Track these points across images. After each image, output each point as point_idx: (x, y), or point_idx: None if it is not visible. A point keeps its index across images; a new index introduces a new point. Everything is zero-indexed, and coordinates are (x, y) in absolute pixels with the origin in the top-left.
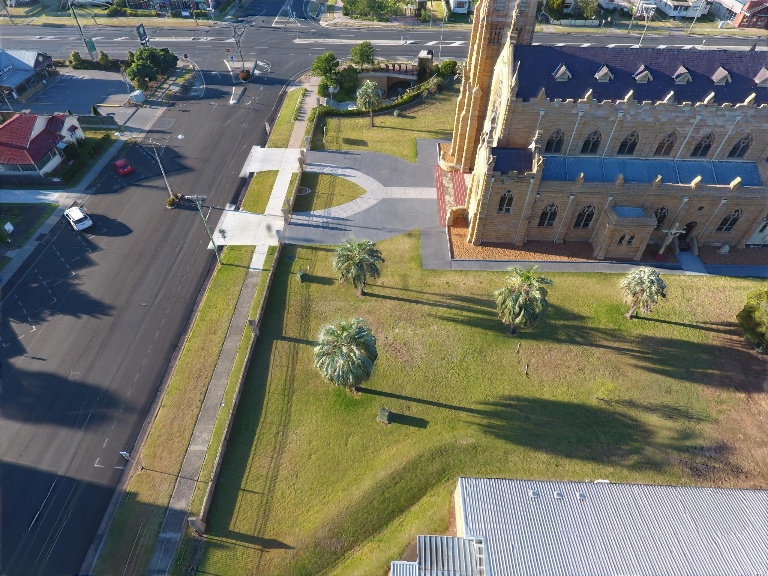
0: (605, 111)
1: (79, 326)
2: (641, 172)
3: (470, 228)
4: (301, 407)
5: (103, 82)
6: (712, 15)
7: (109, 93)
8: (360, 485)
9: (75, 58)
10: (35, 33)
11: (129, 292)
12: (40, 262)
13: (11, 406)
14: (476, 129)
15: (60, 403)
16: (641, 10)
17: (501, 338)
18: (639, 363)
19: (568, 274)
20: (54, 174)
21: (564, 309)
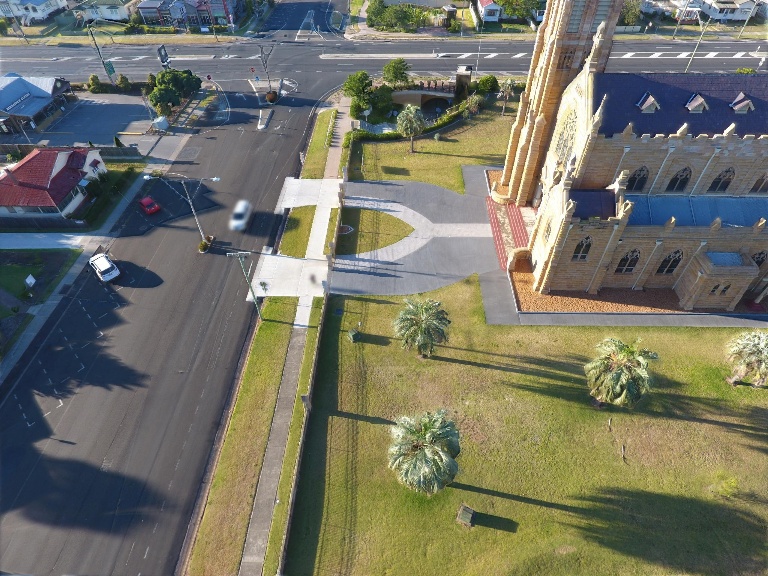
0: (699, 147)
1: (110, 400)
2: (735, 212)
3: (538, 276)
4: (368, 504)
5: (123, 107)
6: (760, 17)
7: (130, 119)
8: None
9: (94, 82)
10: (51, 54)
11: (164, 357)
12: (65, 320)
13: (38, 504)
14: (536, 160)
15: (93, 500)
16: (684, 14)
17: (588, 412)
18: (754, 443)
19: (654, 329)
20: (76, 214)
21: (655, 373)
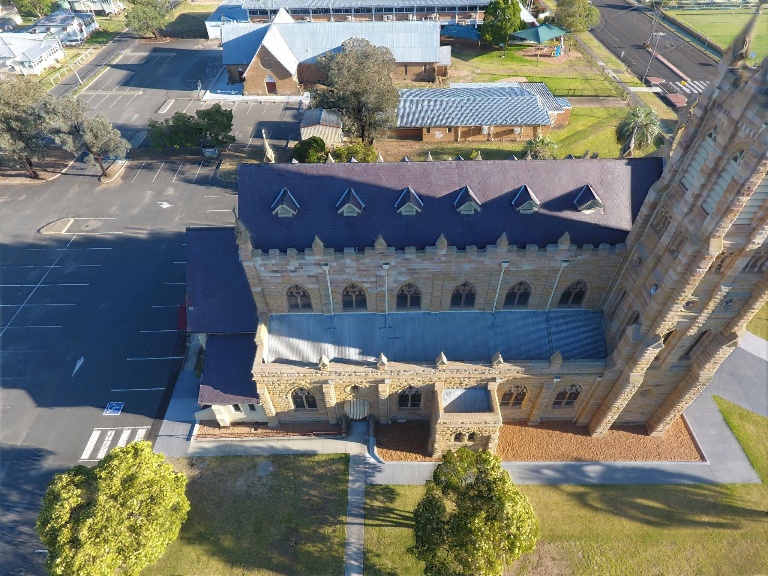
0: None
1: None
2: None
3: None
4: None
5: None
6: None
7: None
8: (593, 138)
9: None
10: None
11: None
12: None
13: None
14: None
15: None
16: None
17: None
18: None
19: None
20: None
21: None
